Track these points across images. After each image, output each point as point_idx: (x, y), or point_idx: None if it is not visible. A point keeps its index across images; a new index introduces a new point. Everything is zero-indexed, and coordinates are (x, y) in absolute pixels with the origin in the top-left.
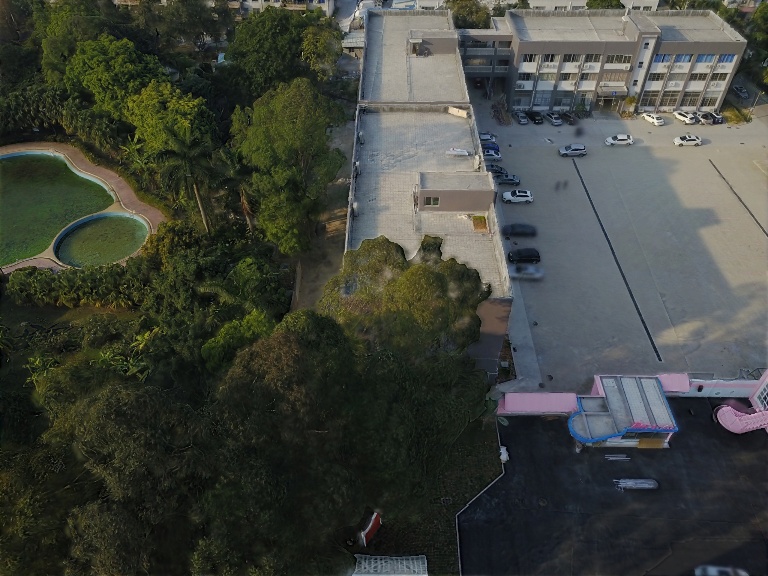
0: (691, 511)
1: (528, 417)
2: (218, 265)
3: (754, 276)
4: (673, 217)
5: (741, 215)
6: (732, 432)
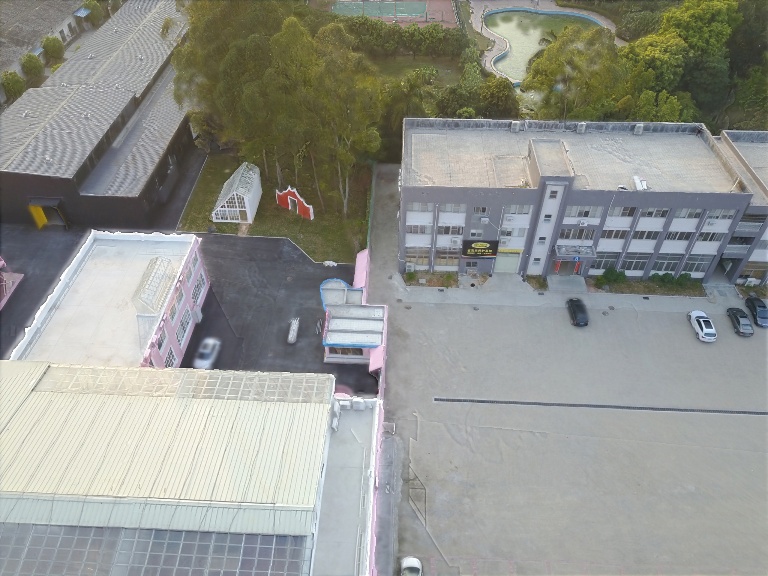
0: (265, 358)
1: None
2: (462, 99)
3: (615, 572)
4: (742, 508)
5: None
6: None
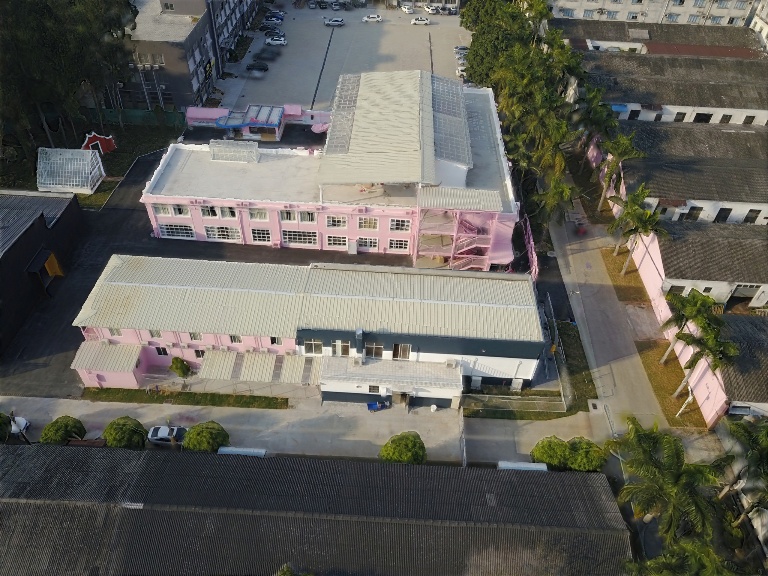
0: None
1: (206, 127)
2: None
3: None
4: (376, 57)
5: (424, 59)
6: (315, 133)
